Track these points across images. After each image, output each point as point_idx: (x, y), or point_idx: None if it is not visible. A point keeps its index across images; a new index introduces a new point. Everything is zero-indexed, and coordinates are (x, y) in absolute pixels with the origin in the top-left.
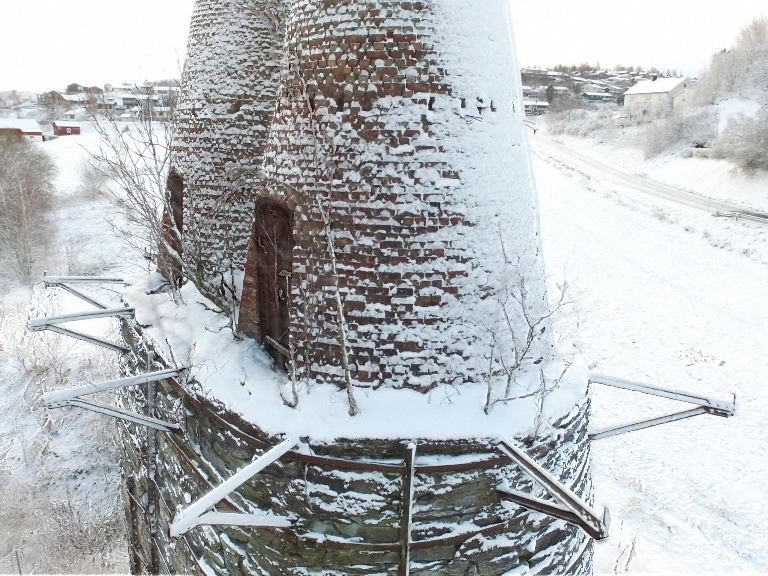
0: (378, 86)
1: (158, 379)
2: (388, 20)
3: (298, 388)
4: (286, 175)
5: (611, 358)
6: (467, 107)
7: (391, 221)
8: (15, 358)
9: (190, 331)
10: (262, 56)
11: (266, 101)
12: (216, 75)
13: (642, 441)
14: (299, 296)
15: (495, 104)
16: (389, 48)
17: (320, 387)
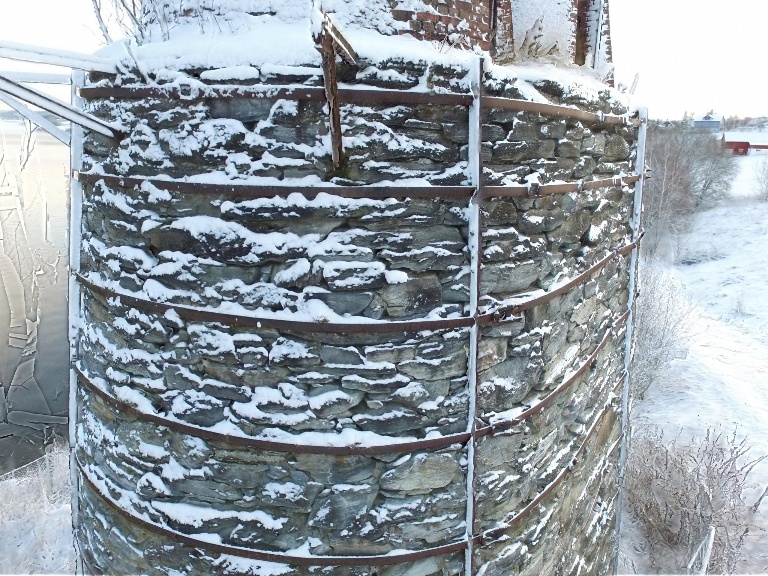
0: None
1: None
2: None
3: None
4: None
5: None
6: None
7: None
8: None
9: None
10: None
11: None
12: None
13: None
14: None
15: None
16: None
17: None
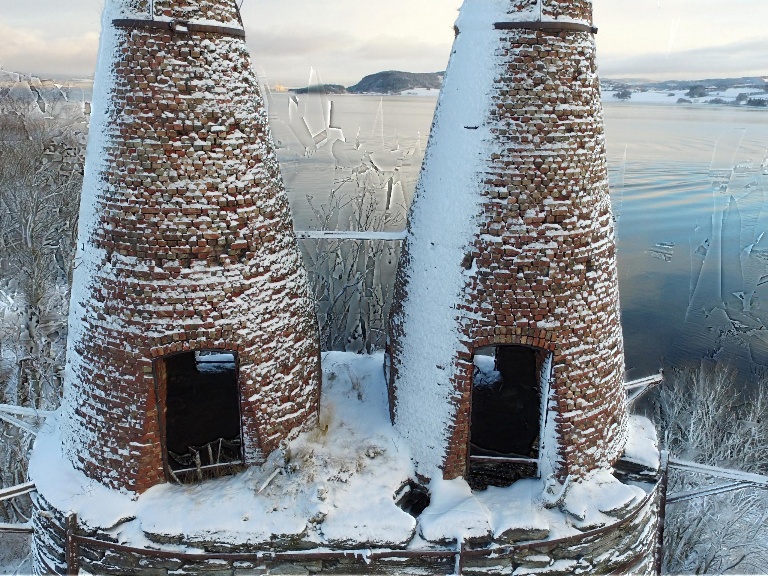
0: None
1: None
2: None
3: None
4: None
5: None
6: None
7: None
8: None
9: None
10: None
11: None
12: None
13: None
14: None
15: None
16: None
17: None
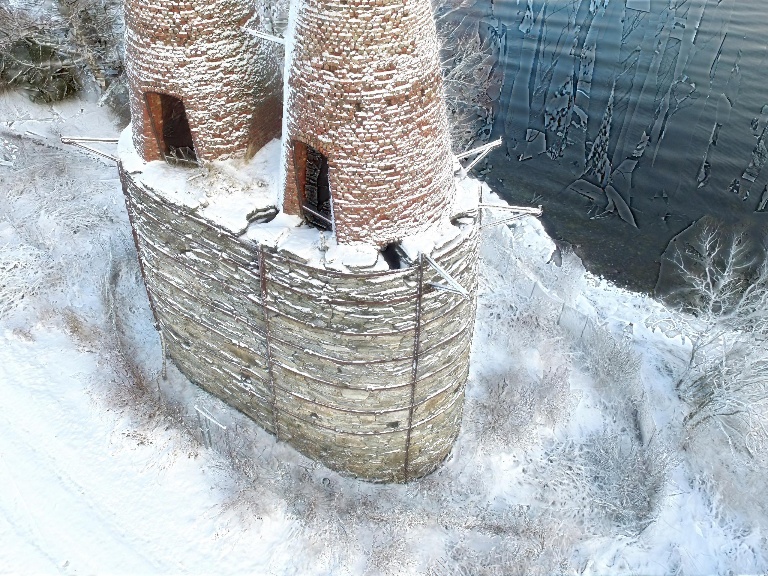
0: None
1: None
2: None
3: None
4: None
5: None
6: None
7: None
8: None
9: None
10: None
11: None
12: None
13: None
14: None
15: None
16: None
17: None
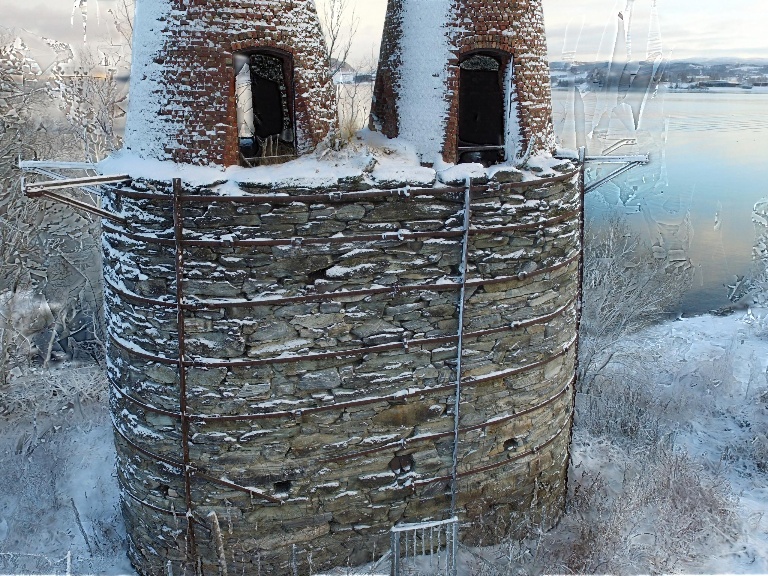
0: None
1: None
2: None
3: None
4: None
5: None
6: None
7: None
8: None
9: None
10: None
11: None
12: None
13: None
14: None
15: None
16: None
17: None
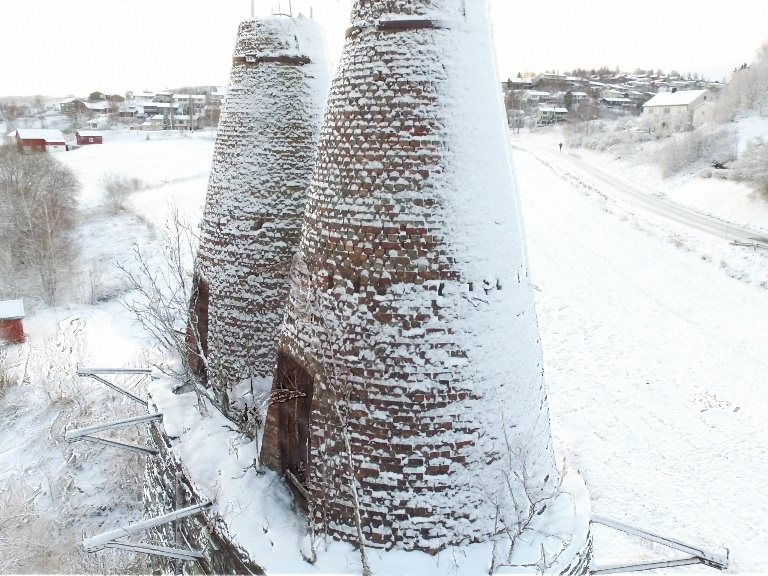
0: (392, 274)
1: (187, 515)
2: (401, 215)
3: (317, 544)
4: (307, 342)
5: (625, 401)
6: (474, 290)
7: (403, 398)
8: (41, 390)
9: (215, 454)
10: (284, 177)
11: (287, 219)
12: (240, 194)
13: (654, 493)
14: (318, 457)
15: (501, 282)
16: (402, 240)
17: (337, 545)
